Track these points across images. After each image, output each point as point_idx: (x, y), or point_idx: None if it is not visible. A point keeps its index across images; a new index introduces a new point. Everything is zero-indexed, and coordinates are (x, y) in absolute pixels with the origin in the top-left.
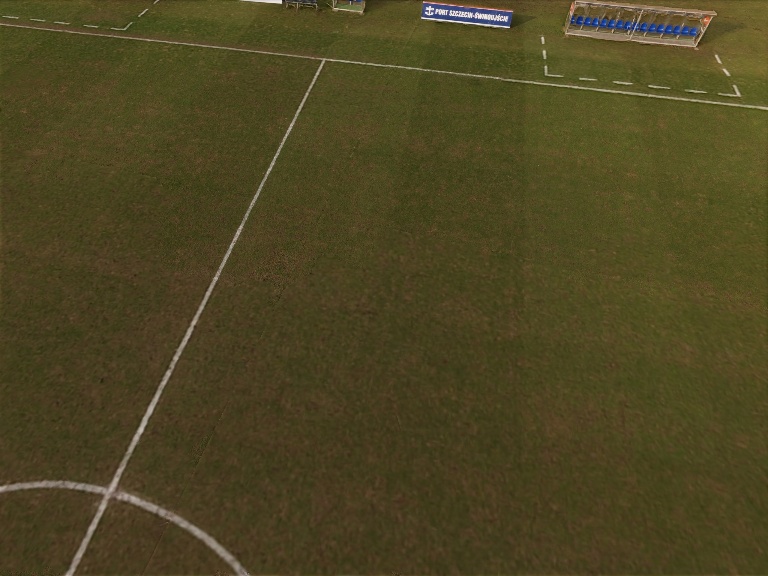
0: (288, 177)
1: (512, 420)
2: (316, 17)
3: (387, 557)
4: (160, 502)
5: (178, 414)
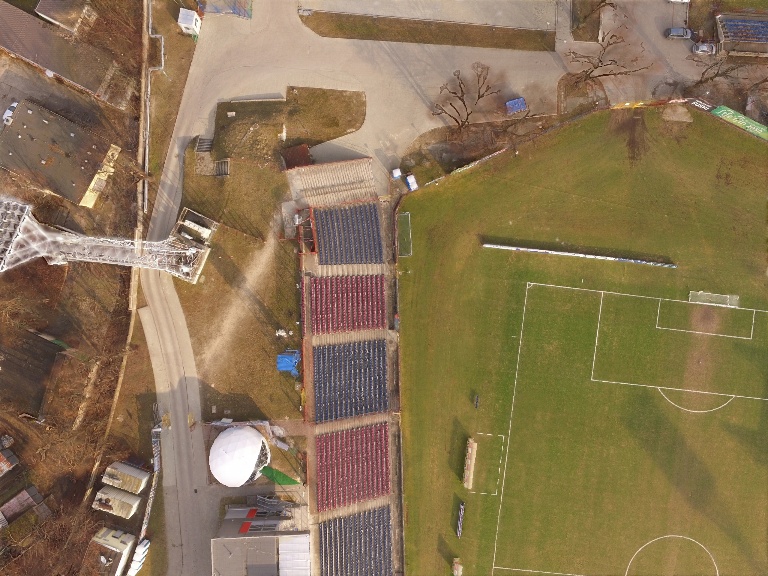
0: (551, 567)
1: (610, 515)
2: (464, 575)
3: (631, 535)
4: (626, 571)
5: (612, 574)
